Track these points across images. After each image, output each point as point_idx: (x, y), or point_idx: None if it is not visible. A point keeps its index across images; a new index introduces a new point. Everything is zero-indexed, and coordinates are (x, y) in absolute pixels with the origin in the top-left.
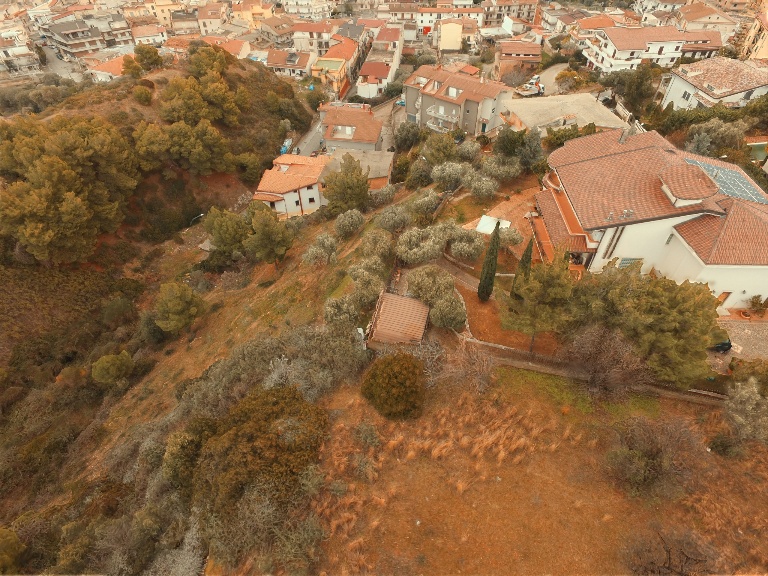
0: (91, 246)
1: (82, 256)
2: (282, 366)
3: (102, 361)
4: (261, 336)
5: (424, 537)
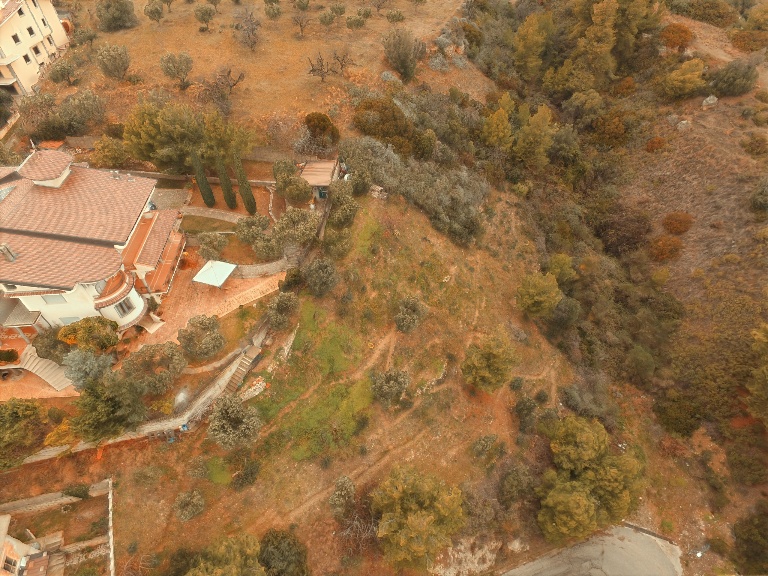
0: (761, 416)
1: (749, 397)
2: (388, 150)
3: (564, 255)
4: (418, 192)
5: (311, 99)
